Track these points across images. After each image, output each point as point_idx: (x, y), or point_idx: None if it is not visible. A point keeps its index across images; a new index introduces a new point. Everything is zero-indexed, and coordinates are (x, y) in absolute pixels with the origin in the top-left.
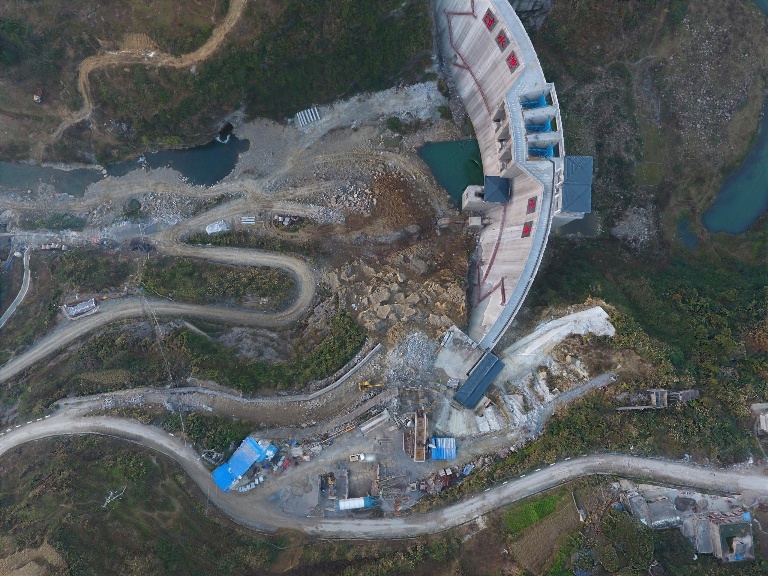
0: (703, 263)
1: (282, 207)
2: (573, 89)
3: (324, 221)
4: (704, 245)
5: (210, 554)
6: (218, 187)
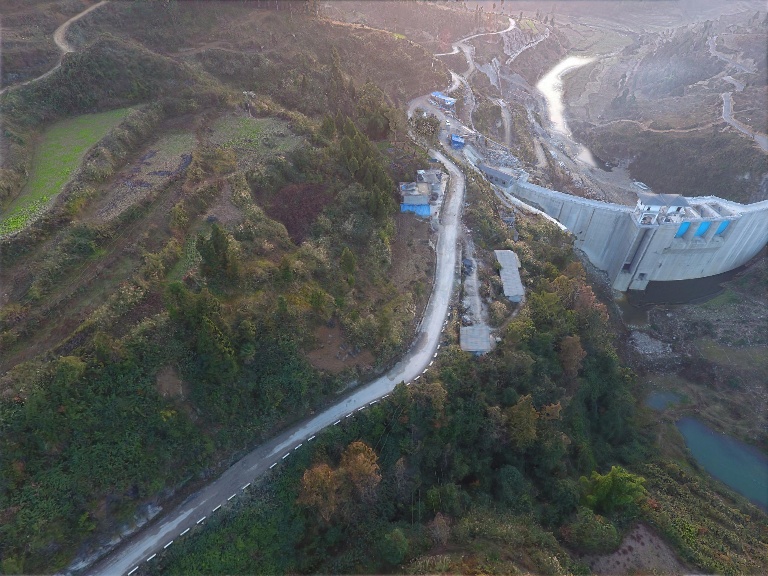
0: (635, 408)
1: (575, 175)
2: (762, 305)
3: (574, 182)
4: (658, 413)
5: (405, 82)
6: (577, 160)
